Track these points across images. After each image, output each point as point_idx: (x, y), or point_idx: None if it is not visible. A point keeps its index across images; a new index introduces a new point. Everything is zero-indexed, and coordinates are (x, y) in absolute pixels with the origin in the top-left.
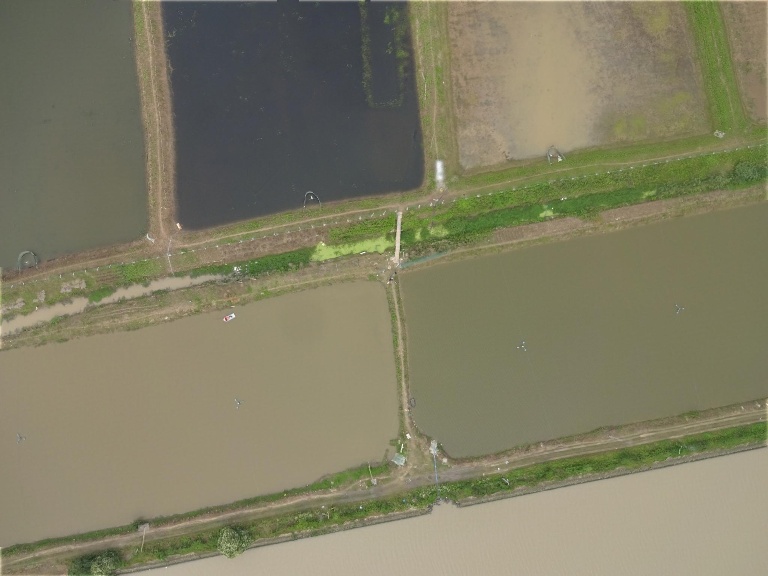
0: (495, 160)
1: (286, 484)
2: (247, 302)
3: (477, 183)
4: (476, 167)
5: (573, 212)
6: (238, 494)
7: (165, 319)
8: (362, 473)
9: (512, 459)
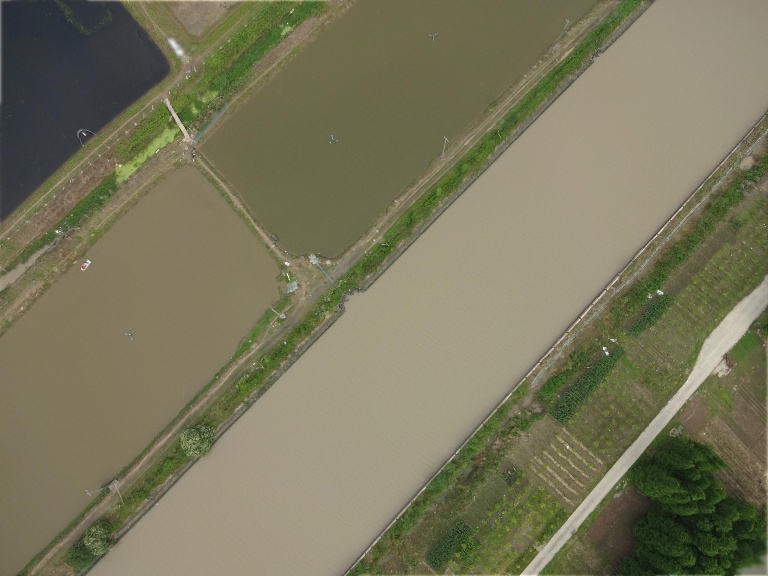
0: (218, 15)
1: (213, 369)
2: (85, 251)
3: (213, 39)
4: (206, 29)
5: (305, 16)
6: (178, 404)
7: (21, 310)
8: (269, 317)
9: (380, 226)
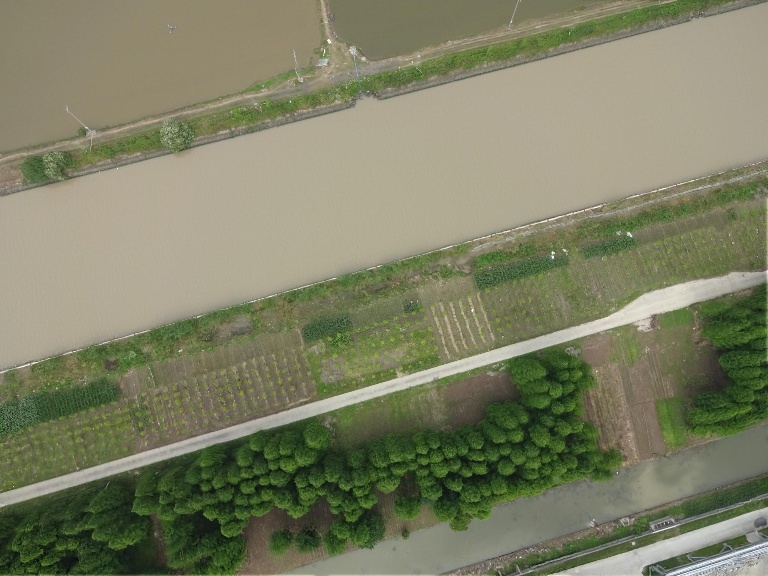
0: None
1: (221, 91)
2: None
3: None
4: None
5: None
6: (177, 103)
7: None
8: (290, 75)
9: (423, 53)
